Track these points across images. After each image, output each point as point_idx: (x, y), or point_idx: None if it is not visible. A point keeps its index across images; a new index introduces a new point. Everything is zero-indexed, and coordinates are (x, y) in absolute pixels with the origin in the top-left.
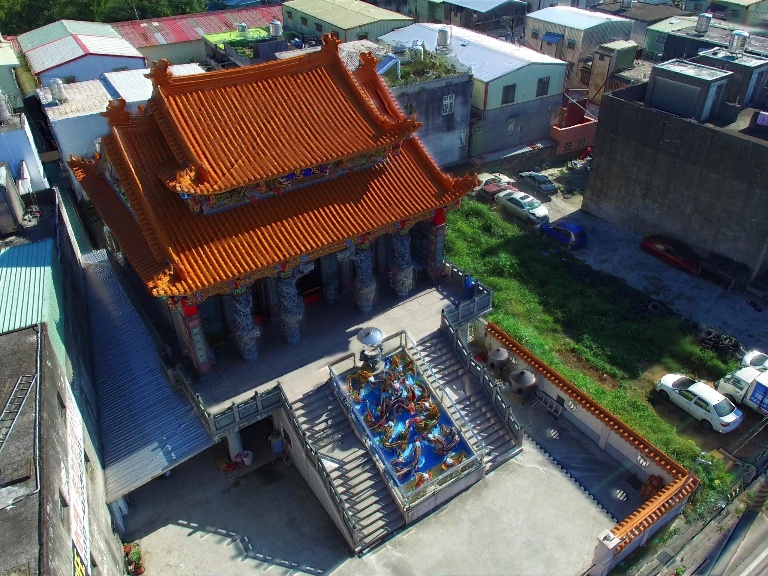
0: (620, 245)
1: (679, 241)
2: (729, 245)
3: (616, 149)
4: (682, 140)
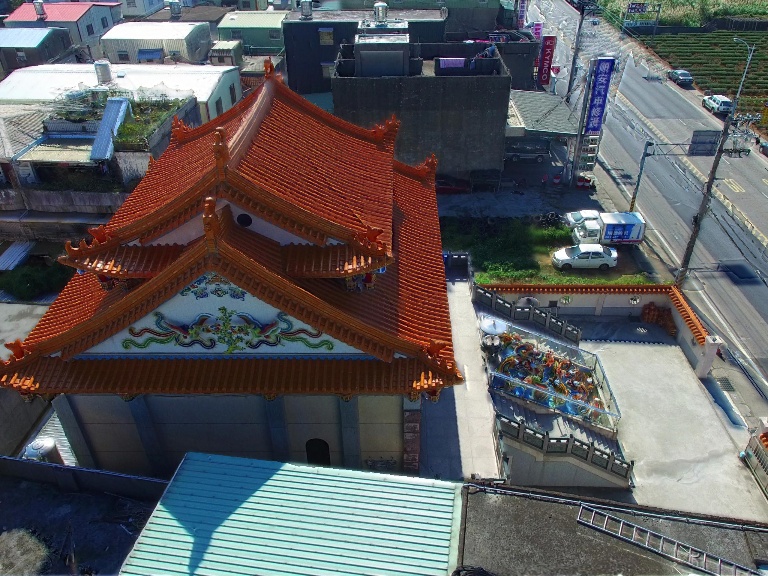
0: None
1: (438, 175)
2: (479, 160)
3: (360, 122)
4: (419, 94)
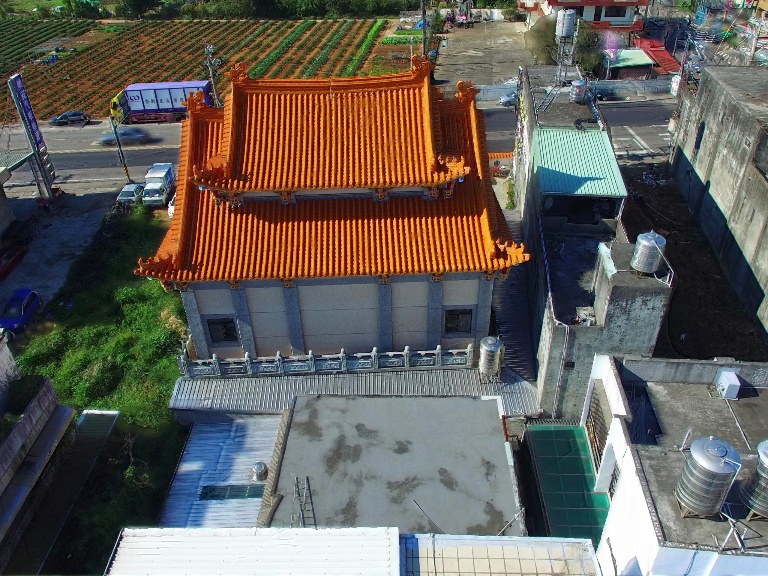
0: (2, 294)
1: None
2: None
3: None
4: None
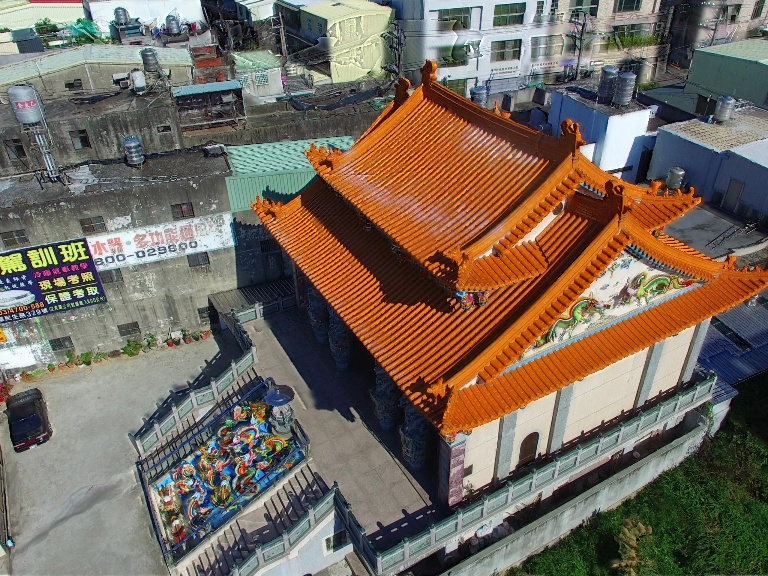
0: None
1: None
2: None
3: None
4: None
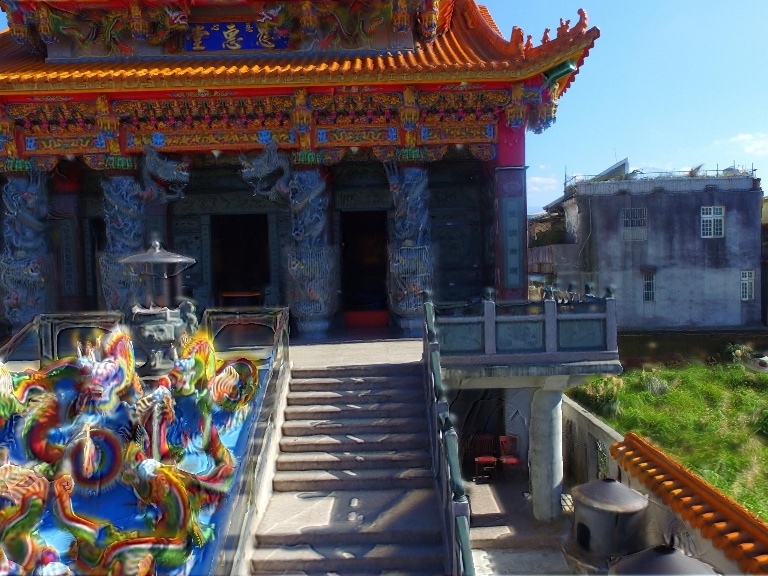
0: None
1: None
2: None
3: None
4: None
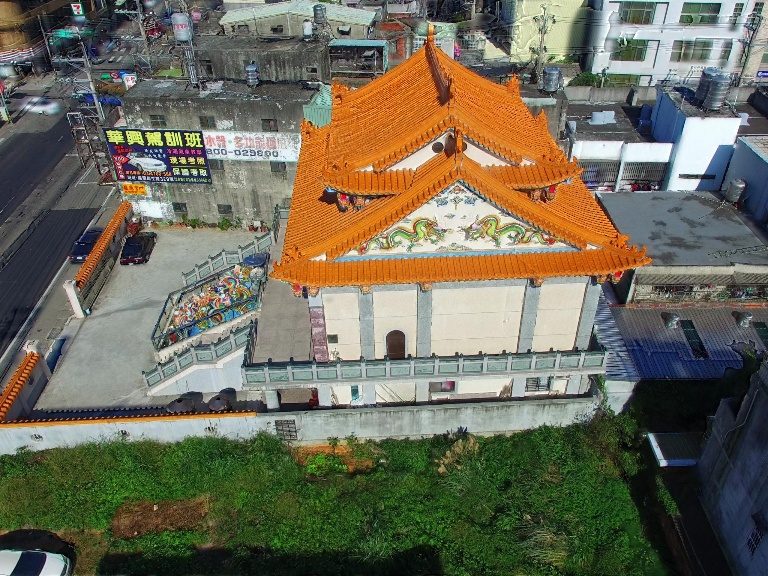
0: None
1: None
2: None
3: None
4: None
